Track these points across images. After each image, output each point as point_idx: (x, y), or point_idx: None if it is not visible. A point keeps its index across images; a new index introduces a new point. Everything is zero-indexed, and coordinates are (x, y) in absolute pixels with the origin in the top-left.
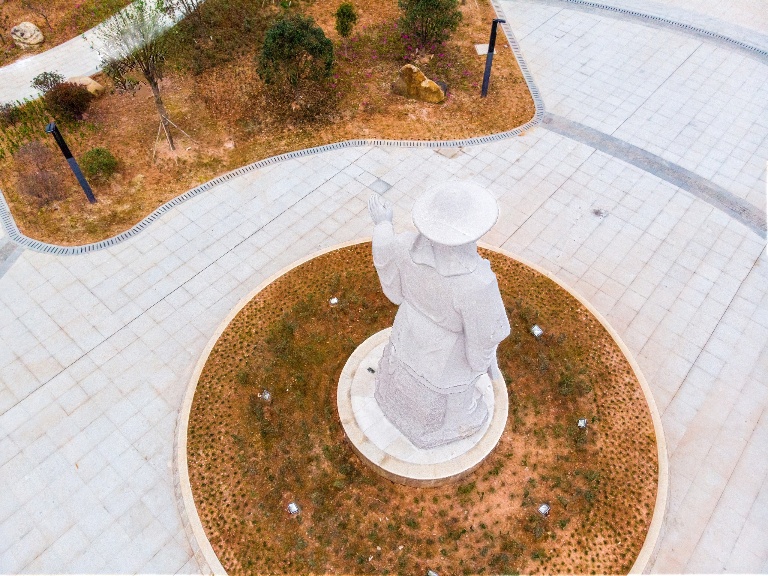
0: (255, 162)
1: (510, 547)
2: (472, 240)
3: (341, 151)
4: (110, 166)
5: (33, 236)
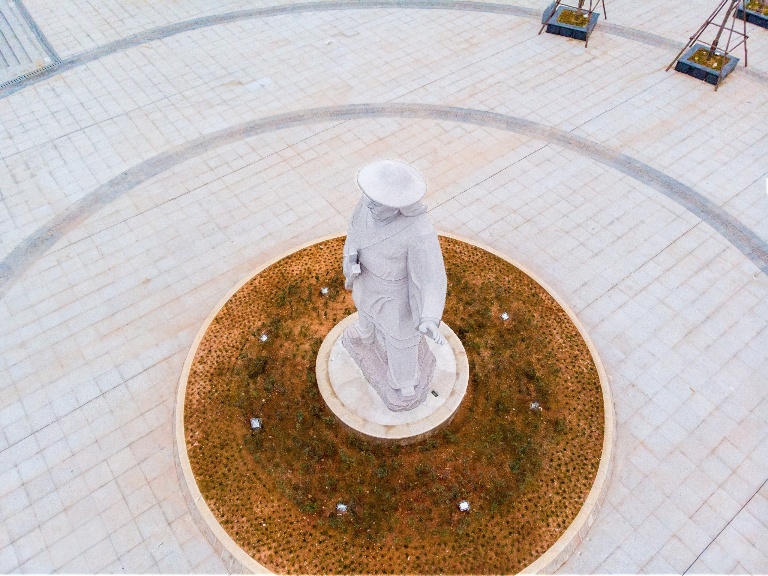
0: None
1: None
2: None
3: None
4: None
5: None
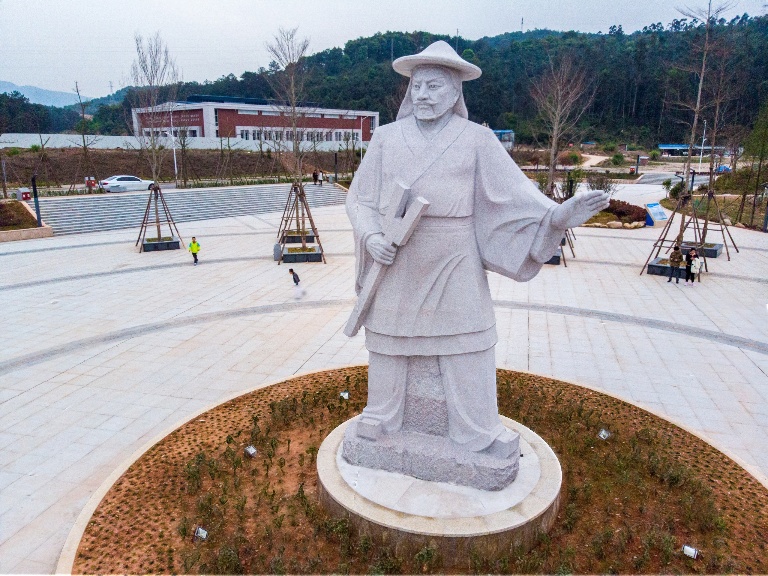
0: None
1: None
2: None
3: None
4: None
5: None
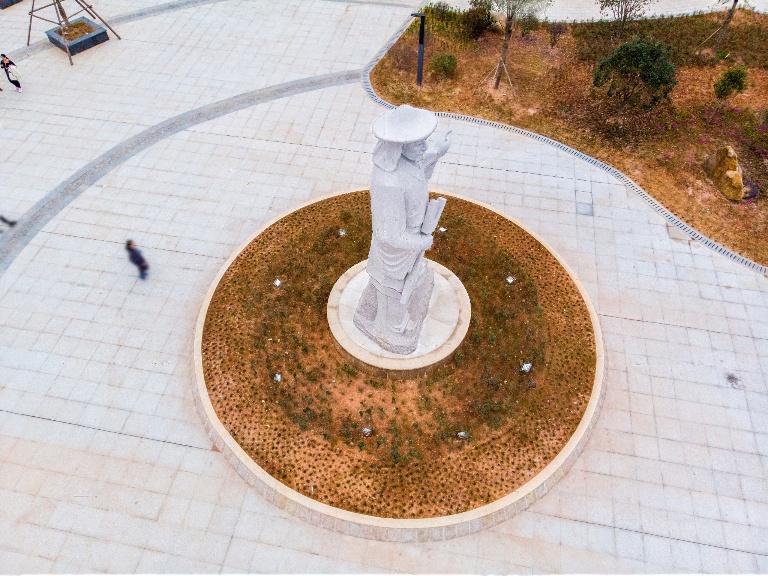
0: (531, 131)
1: (322, 415)
2: (384, 139)
3: (596, 169)
4: (447, 70)
5: (372, 79)
